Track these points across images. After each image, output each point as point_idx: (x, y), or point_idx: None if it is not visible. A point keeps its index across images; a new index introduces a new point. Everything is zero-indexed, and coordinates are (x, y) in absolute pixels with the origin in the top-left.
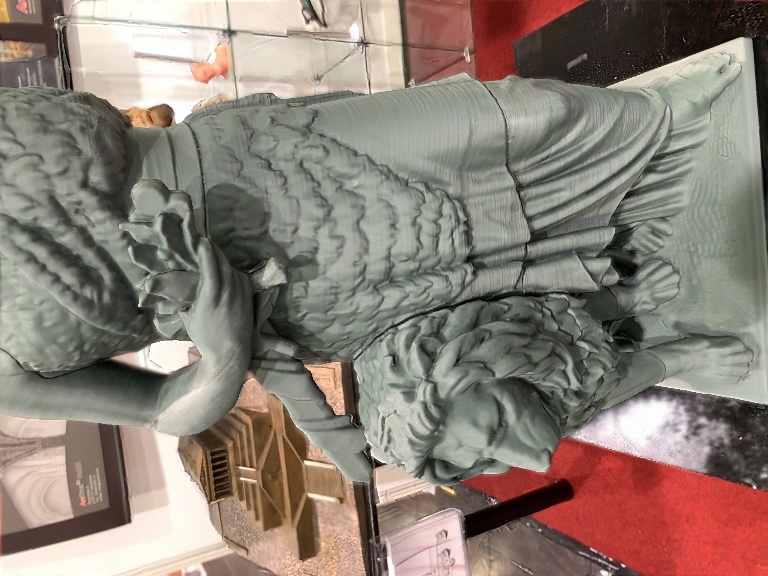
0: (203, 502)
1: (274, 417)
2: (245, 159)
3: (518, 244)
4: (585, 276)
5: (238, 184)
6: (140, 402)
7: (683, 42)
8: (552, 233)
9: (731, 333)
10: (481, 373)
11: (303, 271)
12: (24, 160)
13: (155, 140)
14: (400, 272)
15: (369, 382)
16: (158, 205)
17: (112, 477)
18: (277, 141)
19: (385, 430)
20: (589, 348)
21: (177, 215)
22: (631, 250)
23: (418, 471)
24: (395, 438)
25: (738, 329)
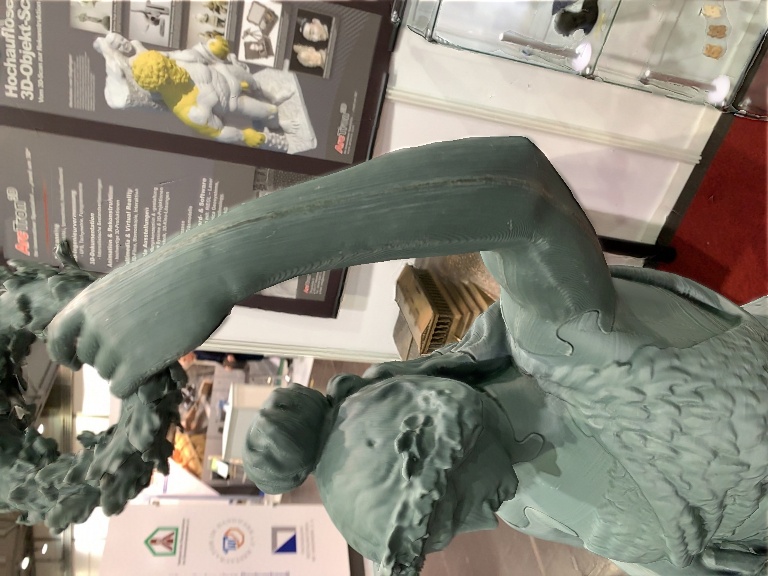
0: (391, 317)
1: None
2: None
3: None
4: None
5: None
6: None
7: None
8: None
9: None
10: None
11: None
12: (736, 469)
13: None
14: None
15: None
16: None
17: (334, 278)
18: None
19: None
20: None
21: None
22: None
23: None
24: None
25: None
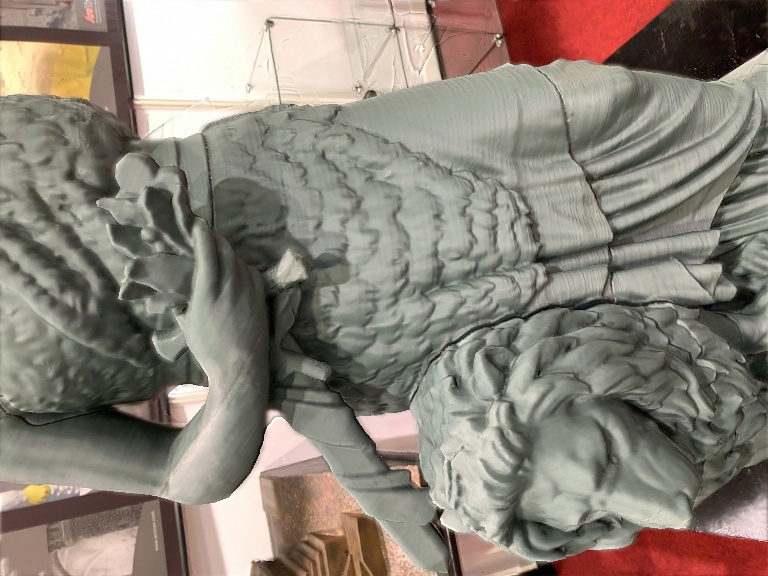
0: None
1: (349, 540)
2: (258, 153)
3: (598, 244)
4: (692, 283)
5: (250, 177)
6: (147, 457)
7: (757, 38)
8: (640, 240)
9: None
10: (572, 385)
11: (331, 273)
12: (2, 148)
13: (160, 144)
14: (452, 274)
15: (428, 421)
16: (144, 179)
17: None
18: (295, 133)
19: (453, 477)
20: (715, 367)
21: (167, 191)
22: (743, 274)
23: (503, 533)
24: (466, 486)
25: None
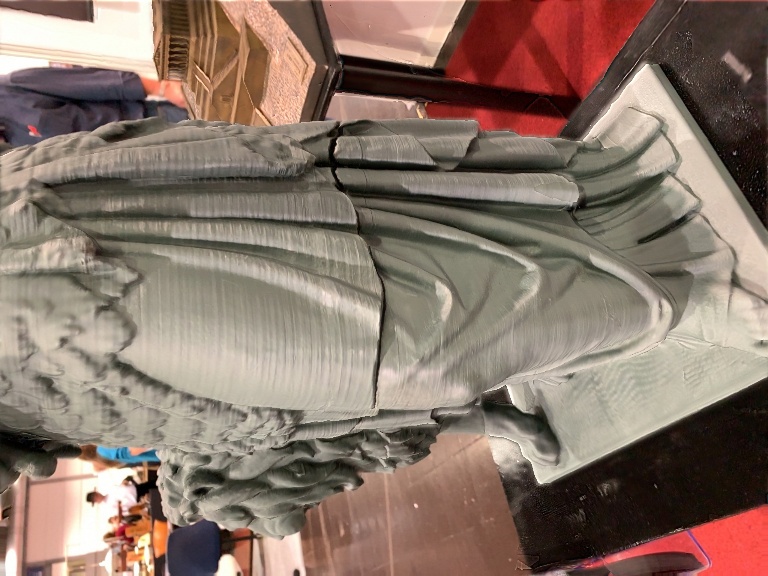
0: None
1: (241, 48)
2: (16, 379)
3: None
4: (428, 422)
5: (3, 402)
6: None
7: None
8: None
9: (560, 440)
10: None
11: None
12: None
13: None
14: None
15: None
16: None
17: None
18: (62, 371)
19: None
20: (387, 466)
21: None
22: None
23: None
24: None
25: (566, 444)
